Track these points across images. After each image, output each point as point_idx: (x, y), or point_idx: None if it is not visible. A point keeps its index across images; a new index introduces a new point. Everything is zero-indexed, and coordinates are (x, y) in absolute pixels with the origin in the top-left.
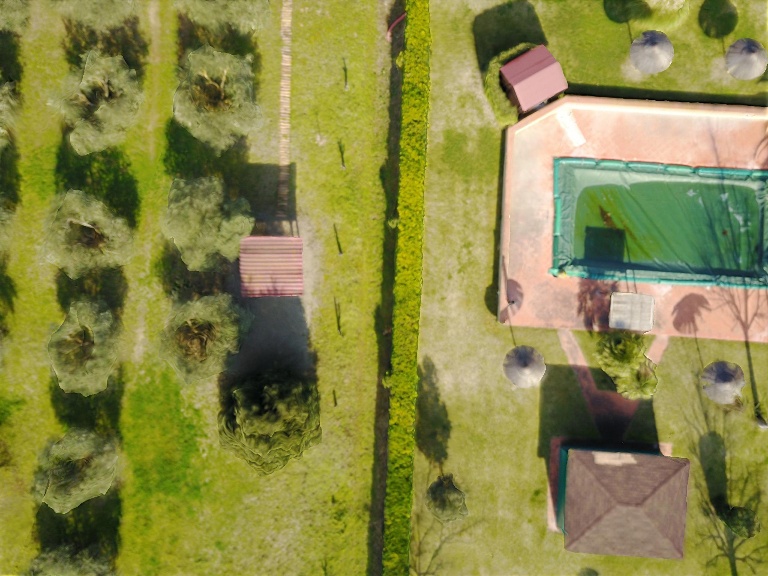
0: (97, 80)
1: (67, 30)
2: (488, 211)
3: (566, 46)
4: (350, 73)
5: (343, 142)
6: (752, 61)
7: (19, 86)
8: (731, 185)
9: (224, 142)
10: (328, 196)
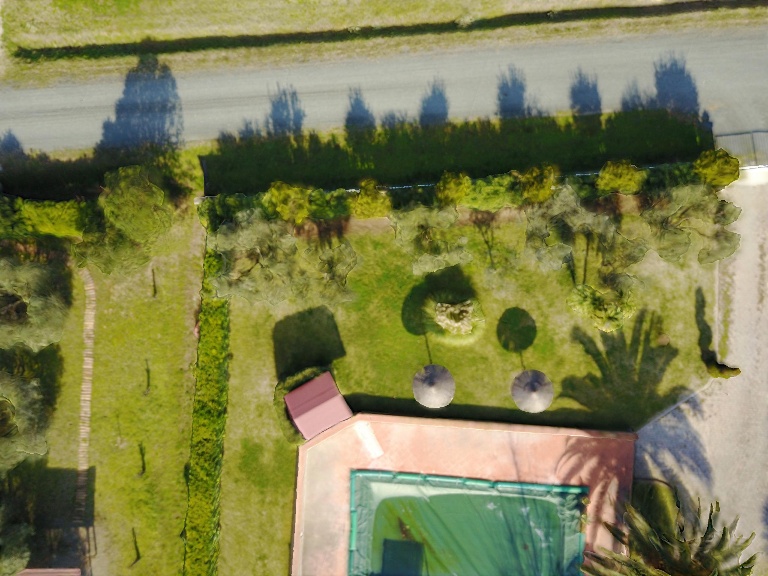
0: None
1: None
2: (284, 523)
3: (364, 357)
4: (153, 374)
5: (144, 444)
6: (534, 399)
7: None
8: (532, 499)
9: (10, 462)
10: (127, 499)
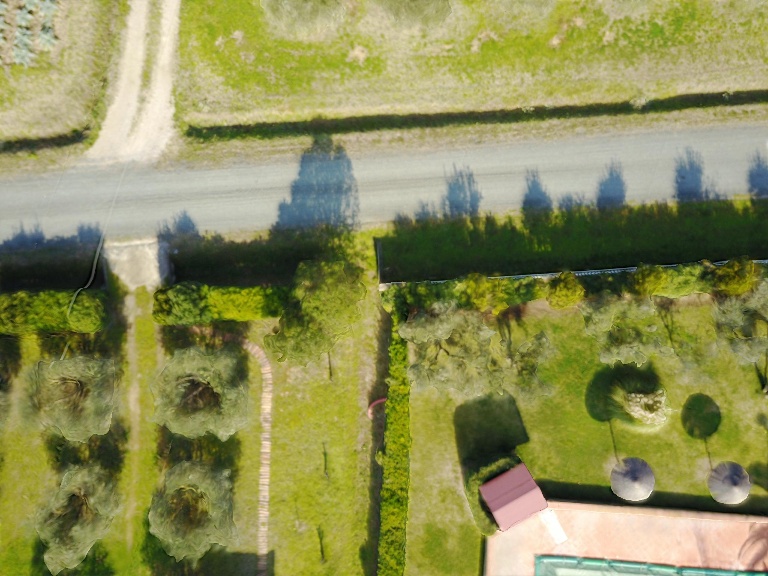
0: (73, 493)
1: (45, 427)
2: None
3: (547, 443)
4: (330, 457)
5: (322, 528)
6: (734, 493)
7: None
8: None
9: (200, 553)
10: None
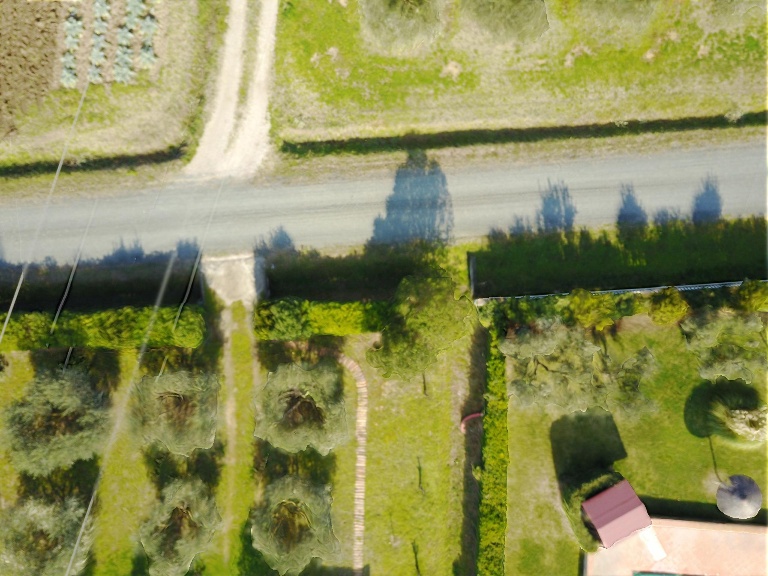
0: (176, 506)
1: (146, 440)
2: None
3: (646, 459)
4: (424, 471)
5: (417, 543)
6: None
7: (97, 494)
8: None
9: (301, 567)
10: None
